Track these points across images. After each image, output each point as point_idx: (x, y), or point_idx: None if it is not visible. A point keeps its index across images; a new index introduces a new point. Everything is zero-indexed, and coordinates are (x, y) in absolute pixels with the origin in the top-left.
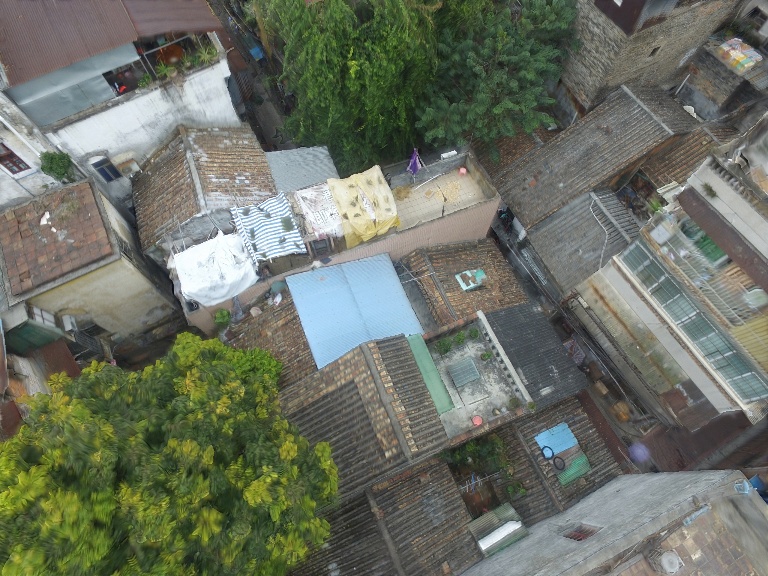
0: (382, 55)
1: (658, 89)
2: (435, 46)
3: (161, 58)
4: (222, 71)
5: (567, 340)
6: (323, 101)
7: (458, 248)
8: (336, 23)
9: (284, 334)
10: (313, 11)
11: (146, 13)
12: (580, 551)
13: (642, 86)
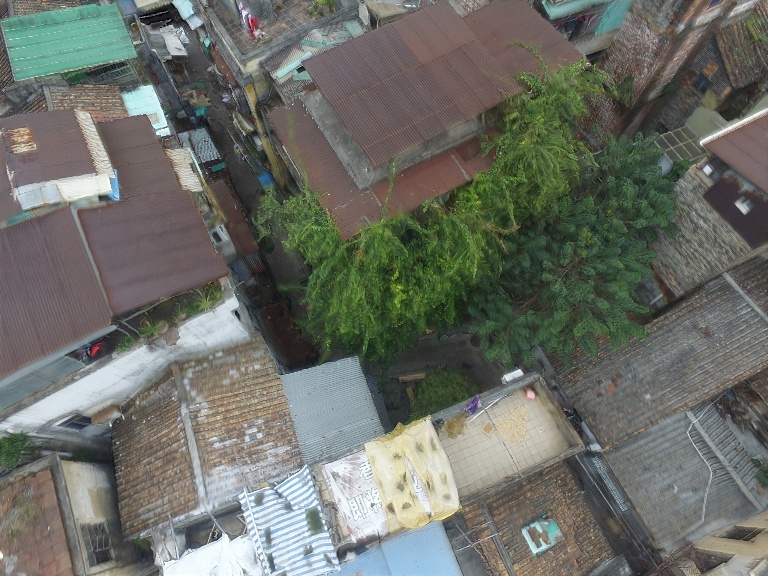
0: (436, 278)
1: (759, 262)
2: (500, 251)
3: (146, 319)
4: (228, 307)
5: (649, 573)
6: (357, 327)
7: (522, 482)
8: (380, 259)
9: None
10: (350, 246)
11: (125, 269)
12: None
13: (742, 262)
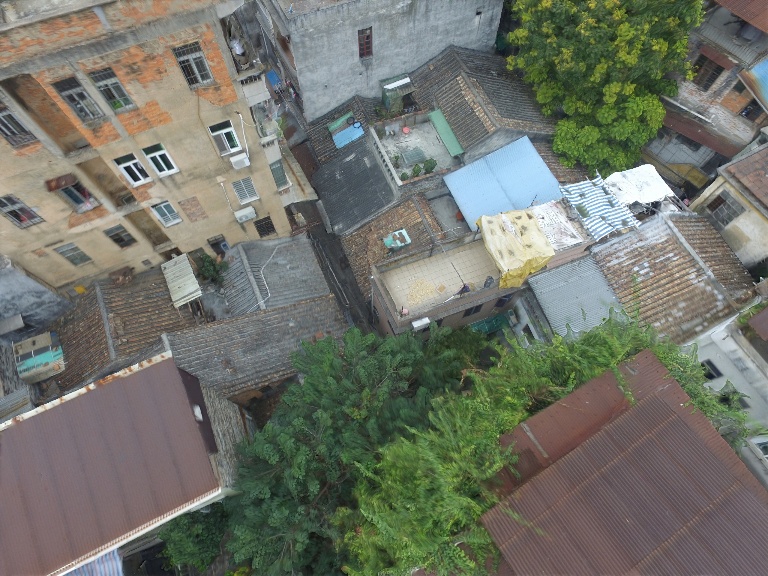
0: None
1: None
2: None
3: None
4: None
5: None
6: None
7: None
8: None
9: (557, 173)
10: None
11: None
12: (379, 8)
13: None
